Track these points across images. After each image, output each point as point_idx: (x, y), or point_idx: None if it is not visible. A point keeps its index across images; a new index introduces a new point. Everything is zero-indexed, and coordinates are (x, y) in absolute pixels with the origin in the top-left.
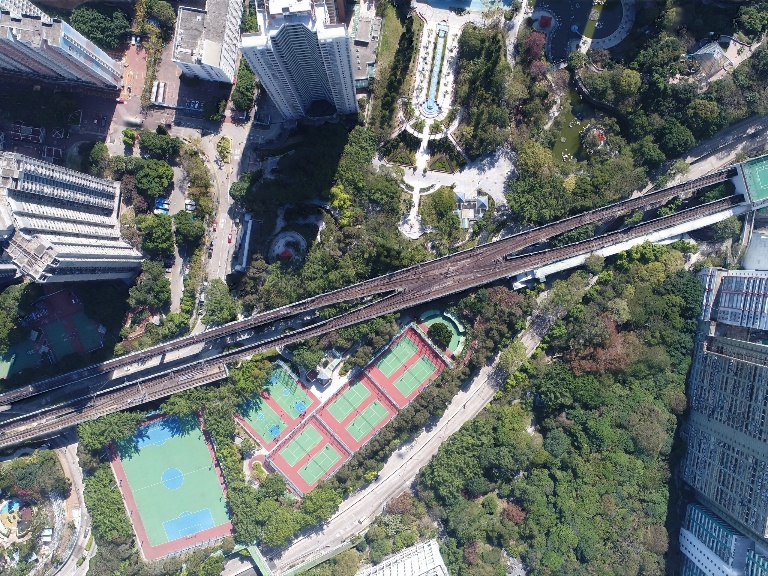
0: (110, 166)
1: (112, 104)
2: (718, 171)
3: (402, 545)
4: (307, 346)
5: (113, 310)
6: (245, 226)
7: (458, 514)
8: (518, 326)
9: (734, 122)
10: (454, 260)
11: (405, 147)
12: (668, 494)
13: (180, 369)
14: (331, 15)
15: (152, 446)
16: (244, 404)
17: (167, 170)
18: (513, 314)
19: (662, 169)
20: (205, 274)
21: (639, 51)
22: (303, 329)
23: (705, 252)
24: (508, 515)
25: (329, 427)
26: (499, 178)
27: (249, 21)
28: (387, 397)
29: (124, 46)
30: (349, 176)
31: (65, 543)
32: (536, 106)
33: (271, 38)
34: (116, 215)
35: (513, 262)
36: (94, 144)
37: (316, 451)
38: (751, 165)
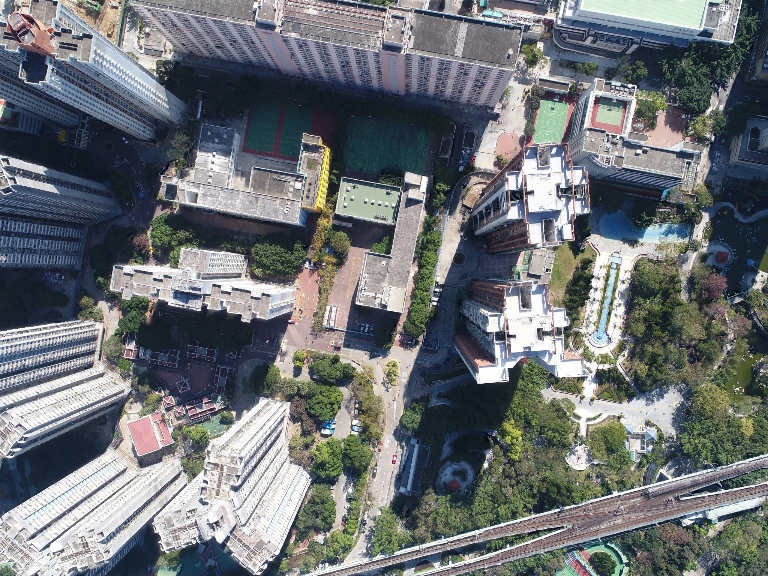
0: (282, 388)
1: (283, 325)
2: None
3: None
4: (471, 575)
5: None
6: (410, 448)
7: None
8: (689, 568)
9: None
10: (625, 498)
11: None
12: None
13: None
14: None
15: None
16: None
17: (338, 395)
18: (685, 558)
19: None
20: (369, 493)
21: None
22: (470, 562)
23: None
24: None
25: None
26: (668, 409)
27: (427, 257)
28: None
29: (297, 269)
30: (521, 412)
31: None
32: (714, 348)
33: None
34: None
35: (685, 503)
36: (268, 367)
37: None
38: None
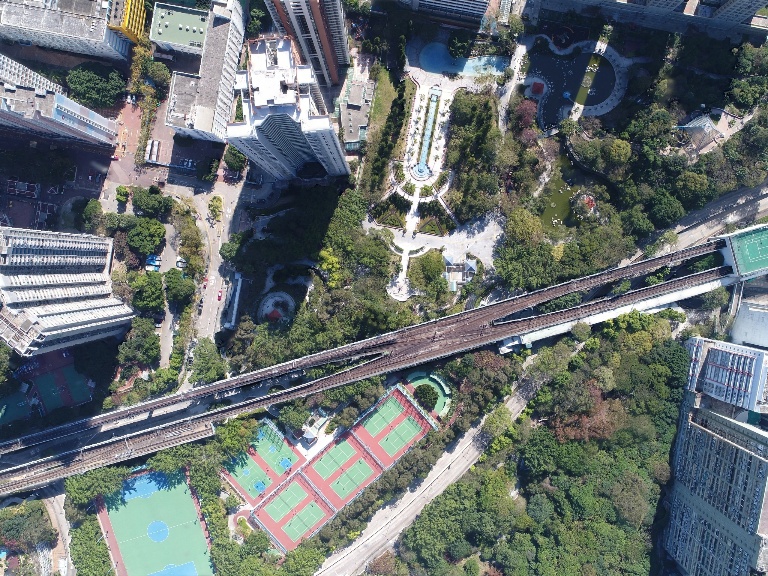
0: (103, 223)
1: (107, 161)
2: (707, 241)
3: None
4: (293, 406)
5: (103, 365)
6: (235, 284)
7: None
8: (503, 392)
9: (724, 193)
10: (441, 324)
11: (395, 209)
12: (649, 565)
13: (167, 426)
14: (318, 98)
15: (139, 499)
16: (230, 460)
17: (159, 228)
18: (498, 380)
19: (651, 237)
20: (194, 330)
21: (630, 121)
22: (289, 390)
23: (693, 320)
24: None
25: (314, 484)
26: (488, 242)
27: None
28: (372, 456)
29: (120, 104)
30: (338, 239)
31: None
32: (526, 174)
33: (256, 127)
34: (108, 271)
35: (500, 328)
36: (88, 201)
37: (301, 508)
38: (740, 238)
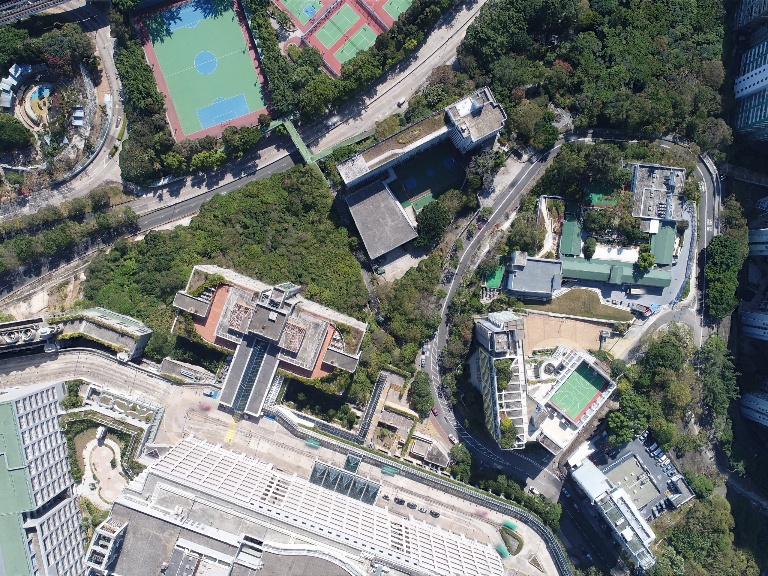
0: None
1: None
2: None
3: None
4: None
5: None
6: None
7: (503, 64)
8: None
9: None
10: None
11: None
12: (723, 31)
13: None
14: None
15: (184, 28)
16: None
17: None
18: None
19: None
20: None
21: None
22: None
23: None
24: None
25: None
26: None
27: None
28: None
29: None
30: None
31: (97, 133)
32: None
33: None
34: None
35: None
36: None
37: (353, 32)
38: None
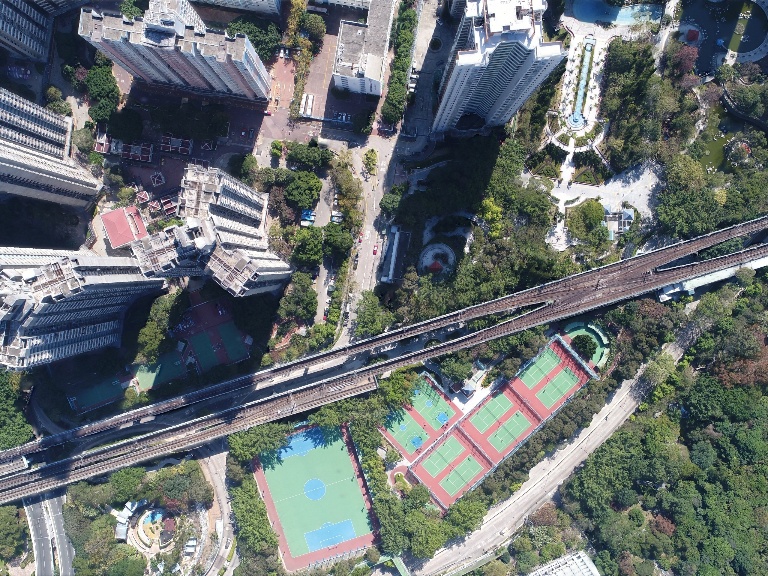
0: (259, 178)
1: (259, 116)
2: None
3: (550, 557)
4: (455, 358)
5: (262, 321)
6: (390, 238)
7: (610, 526)
8: (668, 338)
9: None
10: (604, 272)
11: (551, 160)
12: None
13: (331, 380)
14: None
15: (295, 457)
16: (389, 415)
17: (317, 182)
18: (664, 326)
19: None
20: (350, 285)
21: None
22: (454, 341)
23: None
24: (658, 527)
25: (472, 438)
26: (644, 191)
27: (403, 35)
28: (529, 408)
29: (272, 59)
30: (501, 189)
31: (206, 554)
32: (687, 119)
33: None
34: (263, 227)
35: (662, 275)
36: (244, 156)
37: (458, 462)
38: None
